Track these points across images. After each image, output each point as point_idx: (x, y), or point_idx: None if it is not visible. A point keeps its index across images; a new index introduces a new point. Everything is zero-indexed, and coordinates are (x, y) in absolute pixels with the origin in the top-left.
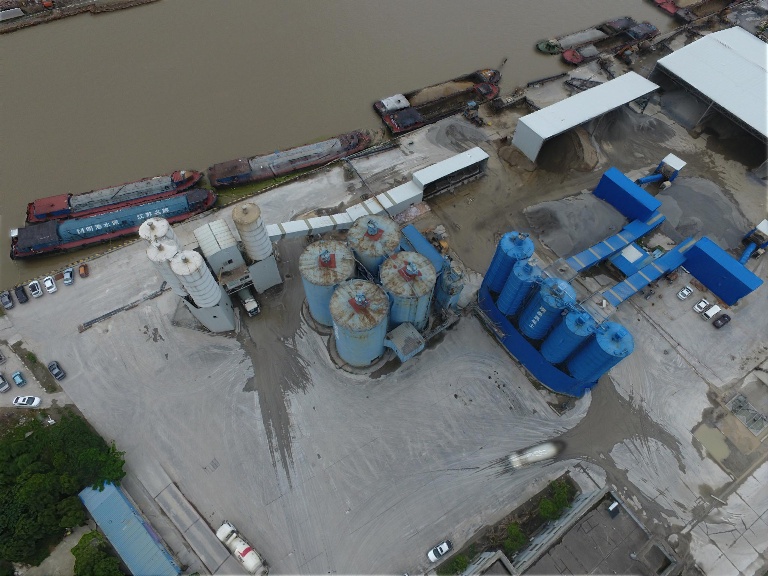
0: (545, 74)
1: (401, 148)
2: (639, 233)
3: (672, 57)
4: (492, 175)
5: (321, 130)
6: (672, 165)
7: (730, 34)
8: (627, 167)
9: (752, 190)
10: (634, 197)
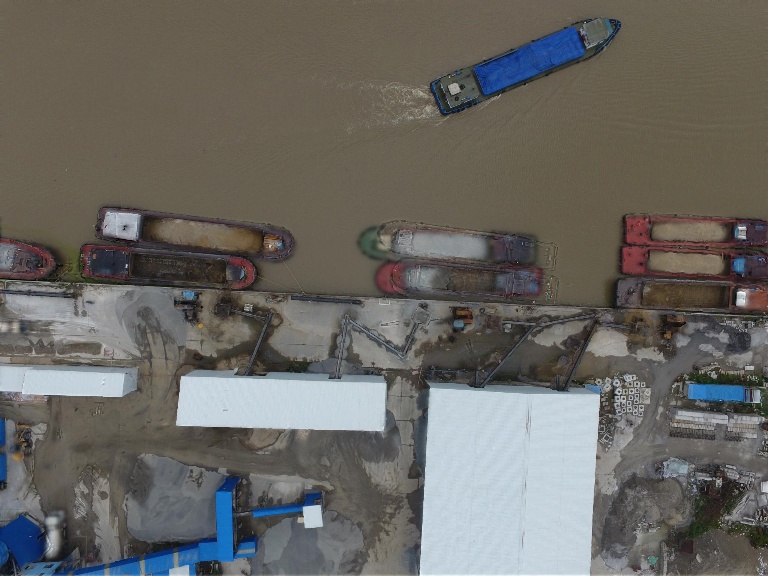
0: (350, 278)
1: (77, 301)
2: (208, 557)
3: (452, 396)
4: (147, 394)
5: (13, 215)
6: (306, 519)
7: (564, 407)
8: (296, 469)
9: (392, 569)
10: (217, 536)
